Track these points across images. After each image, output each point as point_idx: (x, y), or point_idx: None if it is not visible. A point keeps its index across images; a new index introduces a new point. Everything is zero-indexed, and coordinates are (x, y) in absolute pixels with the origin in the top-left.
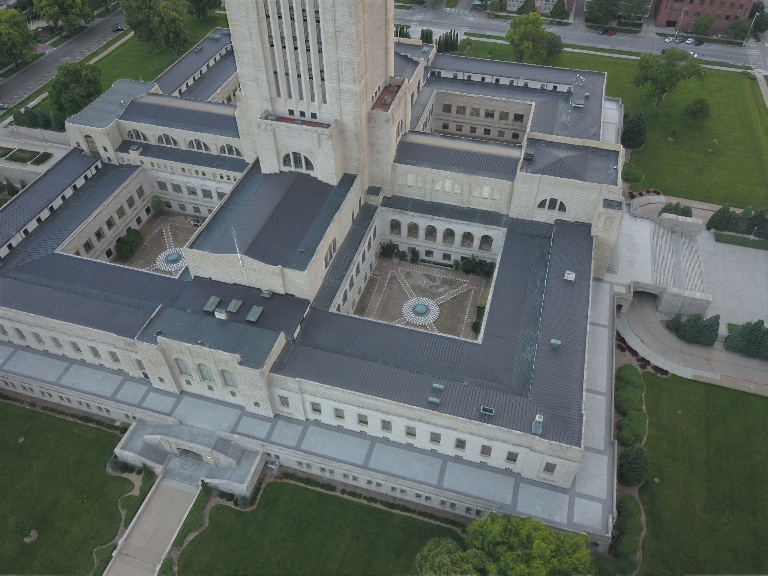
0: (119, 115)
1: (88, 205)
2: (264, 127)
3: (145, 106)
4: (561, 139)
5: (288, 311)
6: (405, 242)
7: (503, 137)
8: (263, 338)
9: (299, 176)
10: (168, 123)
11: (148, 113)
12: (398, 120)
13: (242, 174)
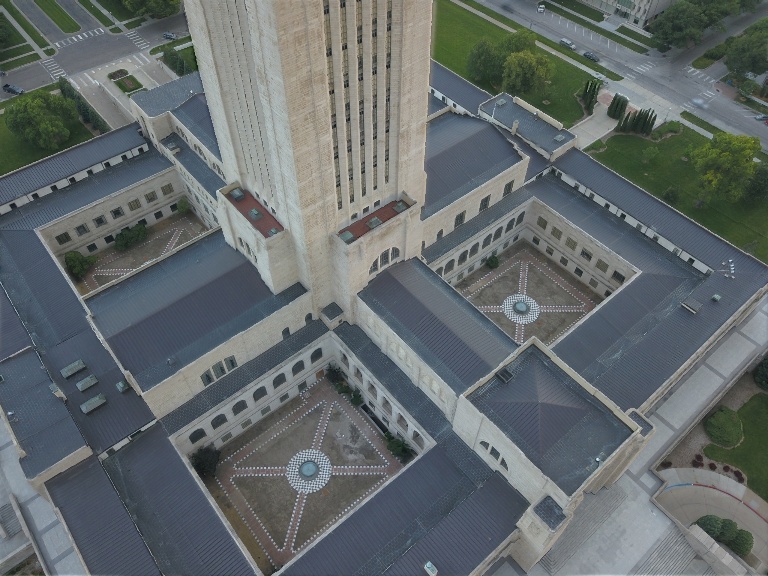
0: (176, 107)
1: (101, 189)
2: (221, 201)
3: (201, 107)
4: (569, 371)
5: (127, 417)
6: (352, 379)
7: (595, 288)
8: (66, 441)
9: (245, 265)
10: (204, 135)
11: (198, 116)
12: (381, 250)
13: (205, 233)
